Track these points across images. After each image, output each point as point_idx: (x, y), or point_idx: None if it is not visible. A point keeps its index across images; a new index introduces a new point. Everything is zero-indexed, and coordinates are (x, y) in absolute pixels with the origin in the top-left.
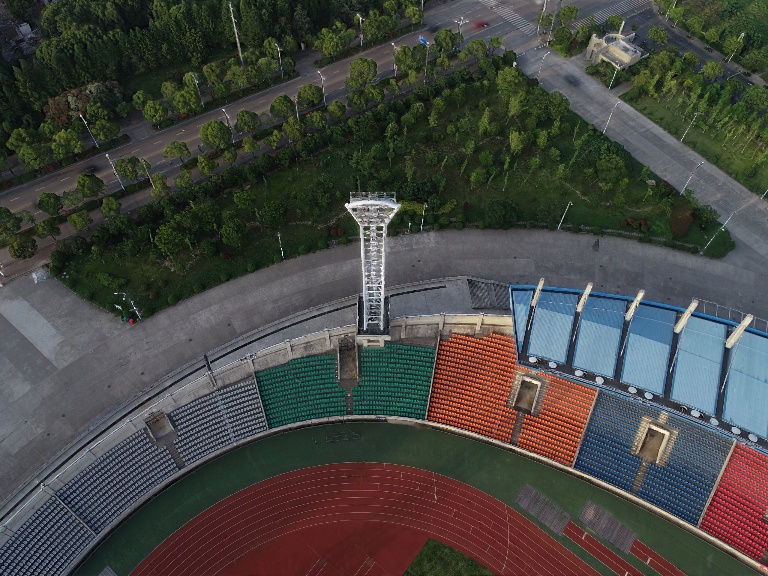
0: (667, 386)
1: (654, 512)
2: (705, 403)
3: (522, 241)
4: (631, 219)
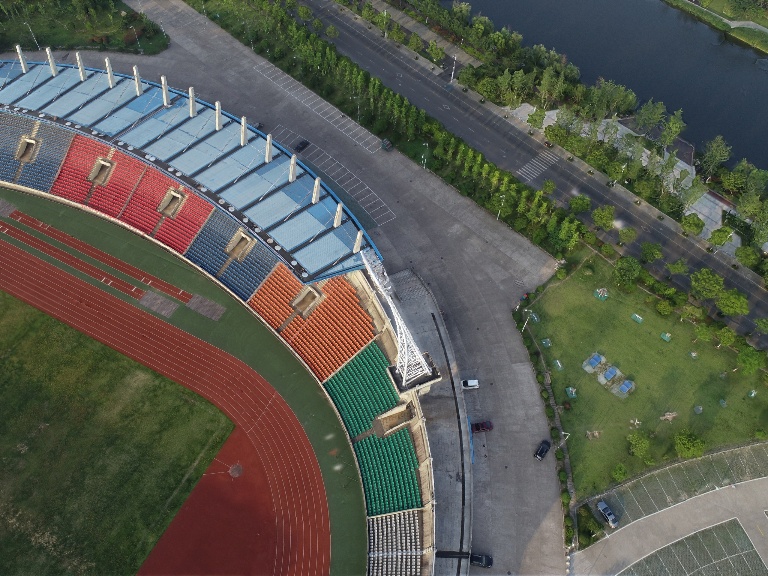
0: None
1: (36, 195)
2: (8, 100)
3: (9, 60)
4: (95, 37)
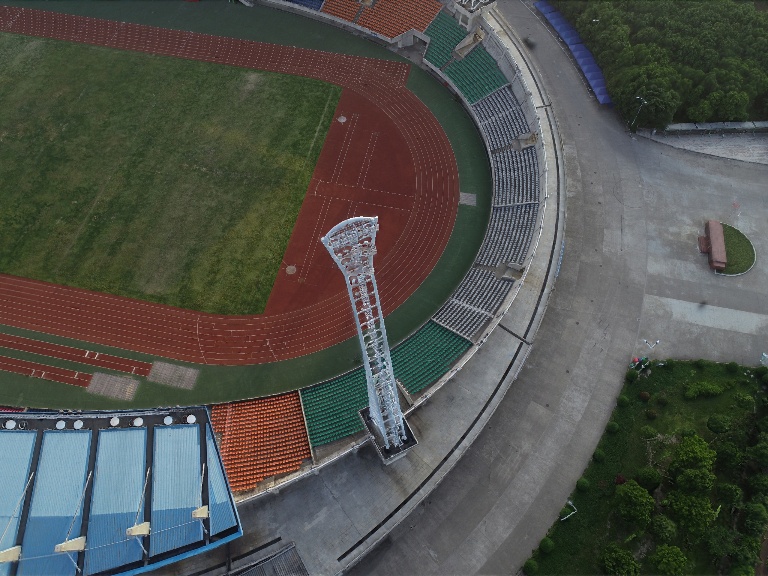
0: (39, 448)
1: None
2: None
3: None
4: None
